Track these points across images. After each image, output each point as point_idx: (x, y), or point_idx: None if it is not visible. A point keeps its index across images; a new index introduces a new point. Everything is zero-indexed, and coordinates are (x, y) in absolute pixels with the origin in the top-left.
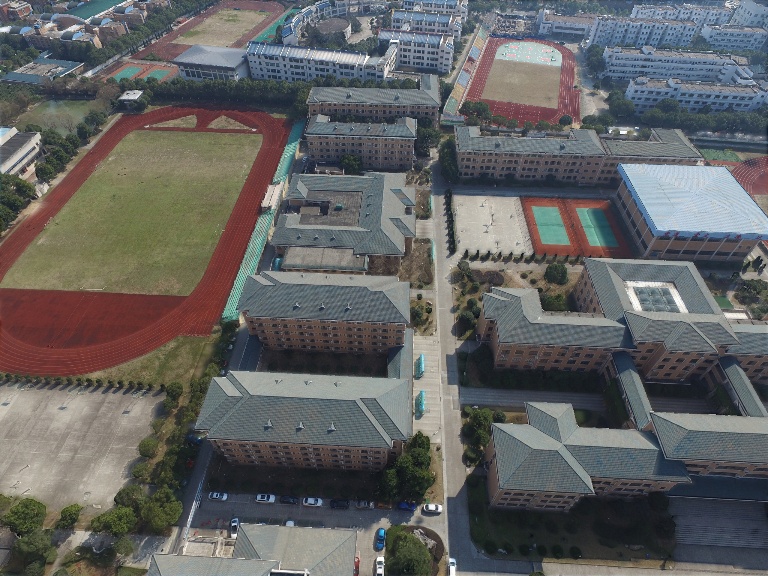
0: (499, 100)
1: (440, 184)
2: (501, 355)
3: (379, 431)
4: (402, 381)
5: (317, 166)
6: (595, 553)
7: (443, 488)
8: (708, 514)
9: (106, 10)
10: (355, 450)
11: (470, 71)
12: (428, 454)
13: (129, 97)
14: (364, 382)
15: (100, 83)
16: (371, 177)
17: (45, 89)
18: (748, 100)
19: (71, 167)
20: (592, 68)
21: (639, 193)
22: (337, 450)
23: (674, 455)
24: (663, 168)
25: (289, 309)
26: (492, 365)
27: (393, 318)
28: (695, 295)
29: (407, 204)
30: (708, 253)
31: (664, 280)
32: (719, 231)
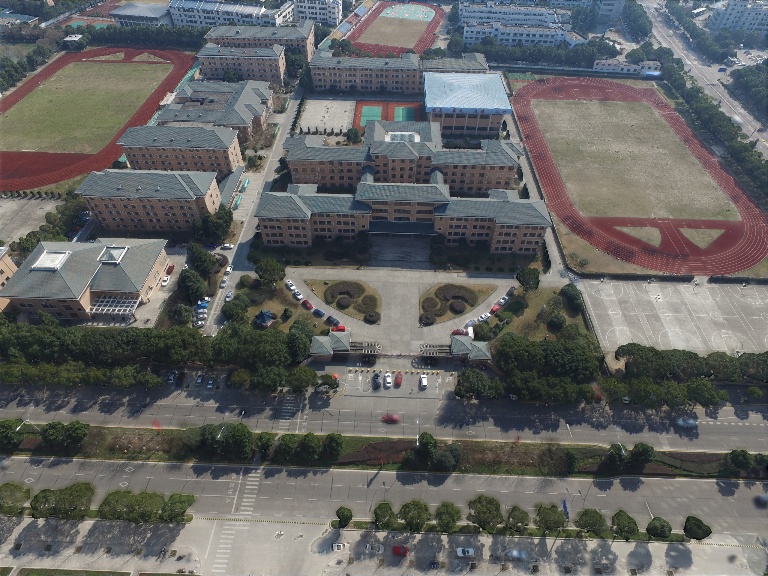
0: (369, 43)
1: (300, 94)
2: (293, 173)
3: (187, 190)
4: (212, 172)
5: (206, 80)
6: (320, 263)
7: (238, 239)
8: (396, 246)
9: None
10: (176, 206)
11: (352, 23)
12: (235, 225)
13: (71, 39)
14: (187, 171)
15: (48, 29)
16: (240, 82)
17: (5, 35)
18: (551, 38)
19: (20, 84)
20: (449, 20)
21: (427, 88)
22: (165, 207)
23: (360, 197)
24: (453, 75)
25: (150, 141)
26: (290, 182)
27: (218, 145)
28: (427, 136)
29: (262, 99)
30: (473, 129)
31: (414, 131)
32: (469, 107)
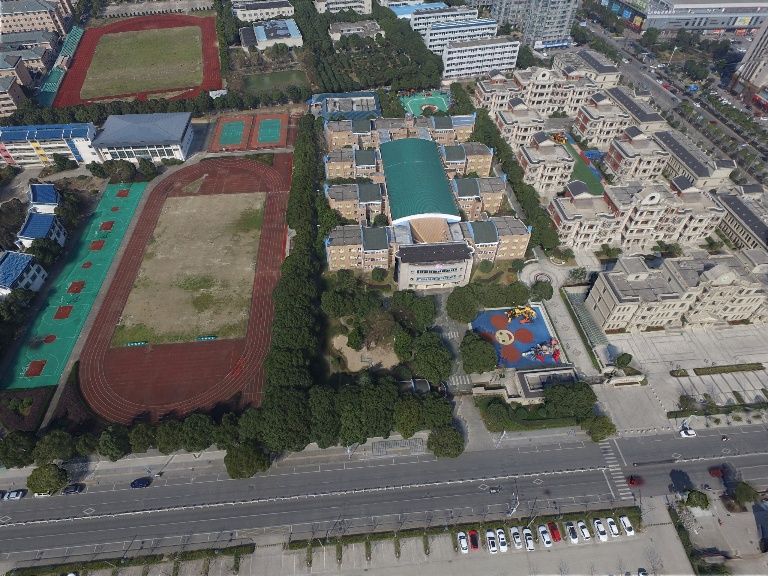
0: None
1: None
2: None
3: None
4: None
5: None
6: None
7: None
8: None
9: (385, 174)
10: None
11: None
12: None
13: (218, 91)
14: None
15: (254, 90)
16: None
17: None
18: None
19: None
20: None
21: None
22: None
23: None
24: None
25: None
26: None
27: None
28: None
29: None
30: None
31: None
32: None
